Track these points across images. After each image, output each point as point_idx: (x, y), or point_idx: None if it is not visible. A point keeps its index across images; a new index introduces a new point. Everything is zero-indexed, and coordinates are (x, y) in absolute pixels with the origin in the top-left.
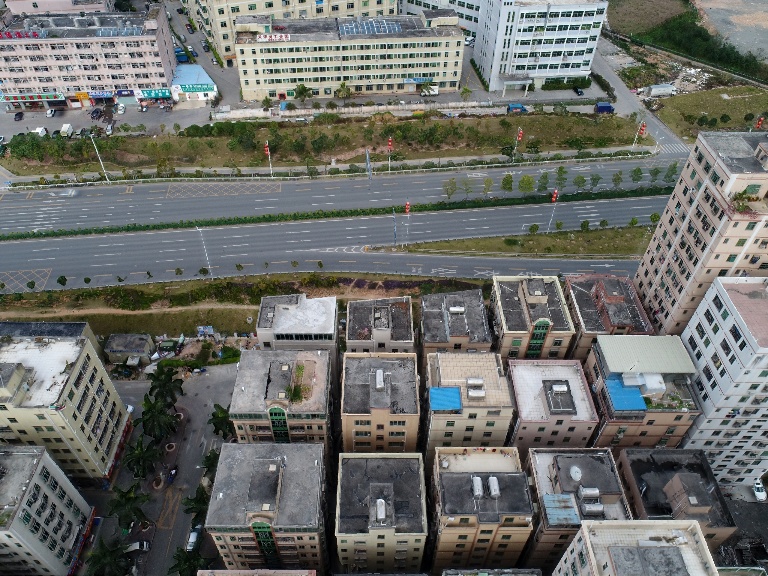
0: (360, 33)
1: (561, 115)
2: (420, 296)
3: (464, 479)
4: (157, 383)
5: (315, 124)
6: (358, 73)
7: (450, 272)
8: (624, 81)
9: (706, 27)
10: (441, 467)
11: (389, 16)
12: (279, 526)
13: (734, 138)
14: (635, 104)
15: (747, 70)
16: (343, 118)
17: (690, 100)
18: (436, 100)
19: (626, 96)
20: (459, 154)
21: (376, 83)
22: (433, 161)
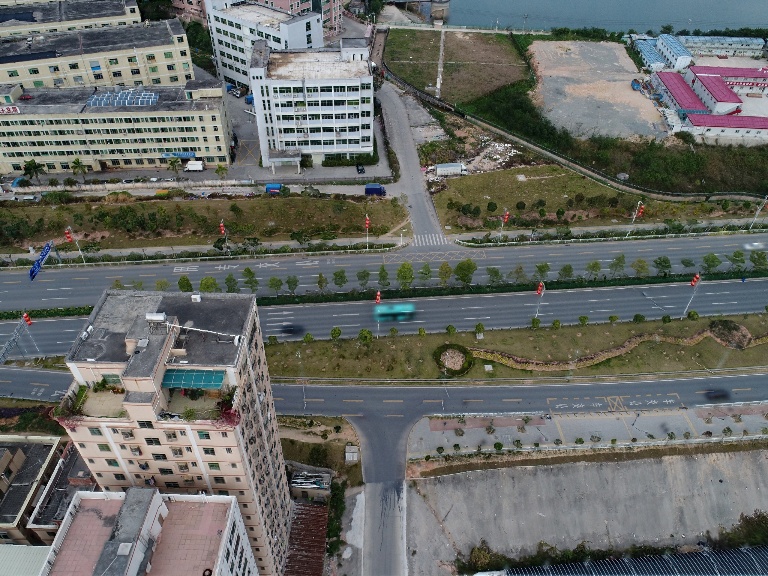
0: (109, 105)
1: (323, 197)
2: (12, 429)
3: None
4: None
5: (41, 204)
6: (108, 147)
7: None
8: (420, 157)
9: (536, 97)
10: None
11: (155, 86)
12: None
13: (150, 299)
14: (417, 184)
15: (559, 147)
16: (75, 197)
17: (480, 181)
18: (198, 176)
19: (412, 175)
20: (180, 243)
21: (132, 157)
22: (146, 251)
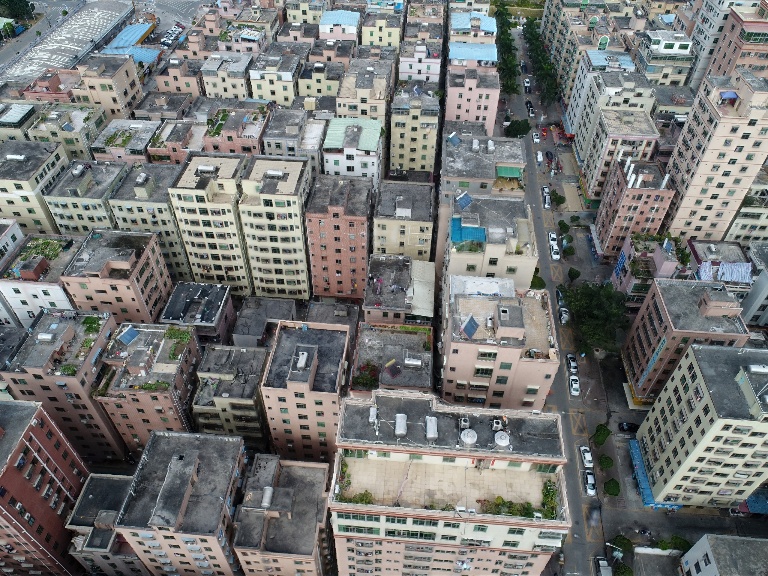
0: None
1: None
2: None
3: None
4: (501, 6)
5: None
6: None
7: None
8: None
9: None
10: None
11: None
12: (592, 3)
13: None
14: None
15: None
16: None
17: None
18: None
19: None
20: None
21: None
22: None
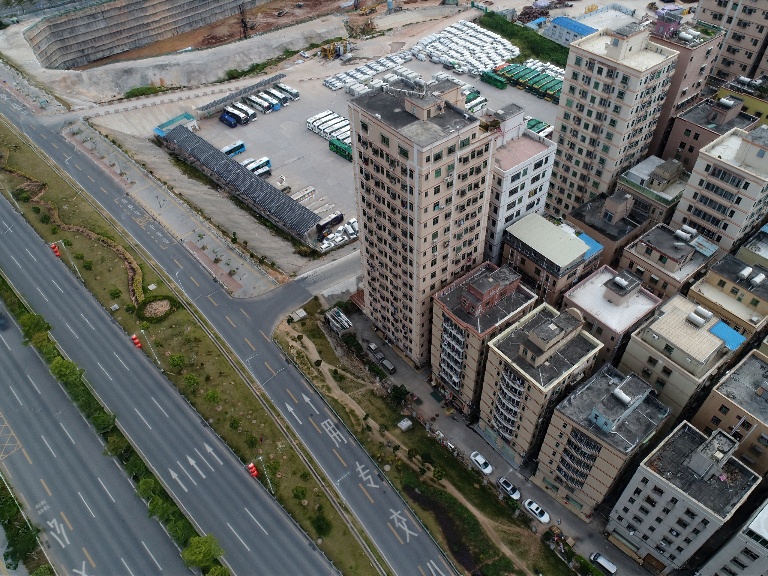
0: None
1: None
2: (515, 570)
3: (759, 293)
4: None
5: None
6: None
7: (436, 569)
8: None
9: None
10: (759, 320)
11: None
12: None
13: None
14: None
15: None
16: None
17: None
18: None
19: None
20: None
21: None
22: None
